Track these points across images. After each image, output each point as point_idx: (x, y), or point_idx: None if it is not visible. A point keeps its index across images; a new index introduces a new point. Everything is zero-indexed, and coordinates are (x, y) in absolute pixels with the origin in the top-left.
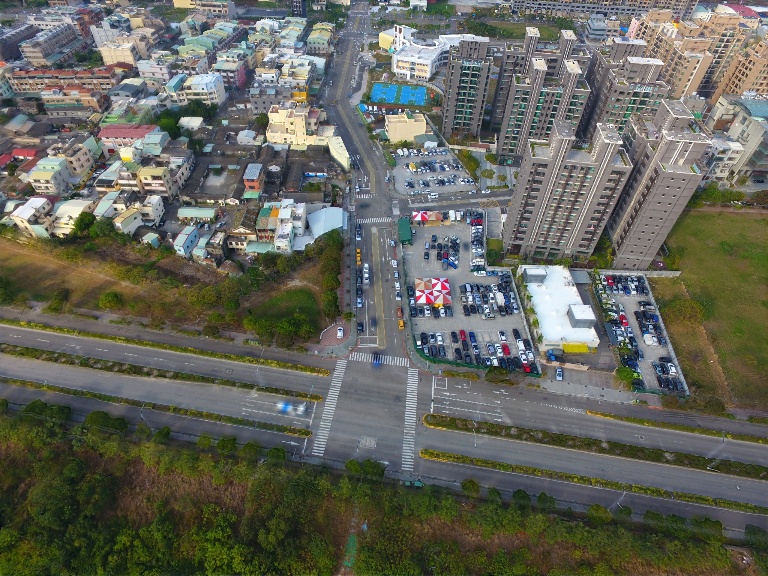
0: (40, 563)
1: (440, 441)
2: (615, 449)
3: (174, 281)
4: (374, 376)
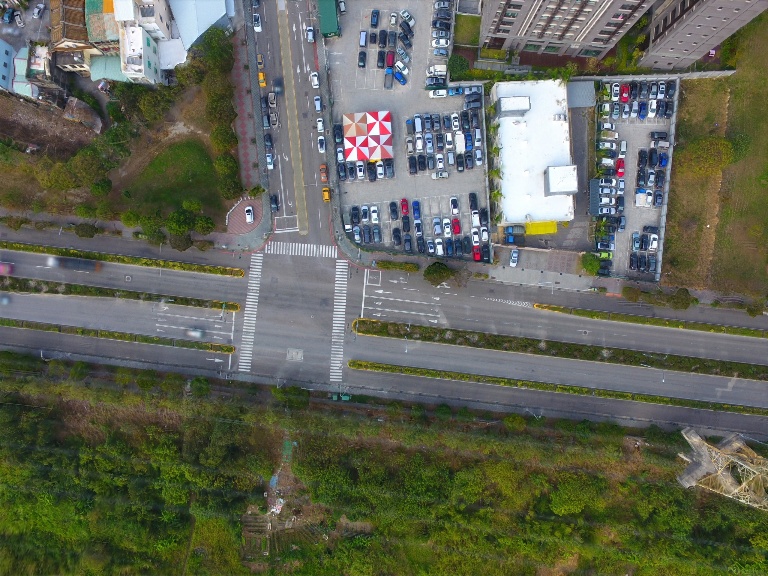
0: (24, 474)
1: (370, 349)
2: (552, 349)
3: (8, 154)
4: (296, 274)
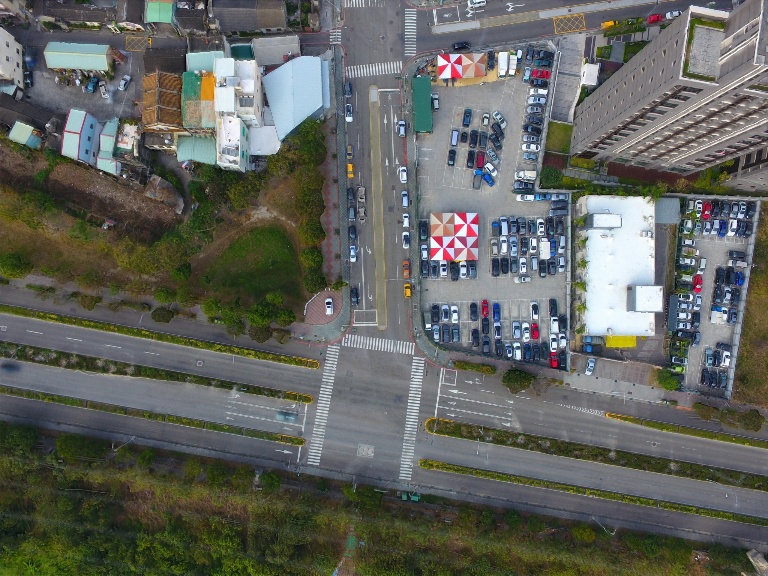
0: (76, 558)
1: (441, 449)
2: (621, 460)
3: (88, 232)
4: (372, 369)
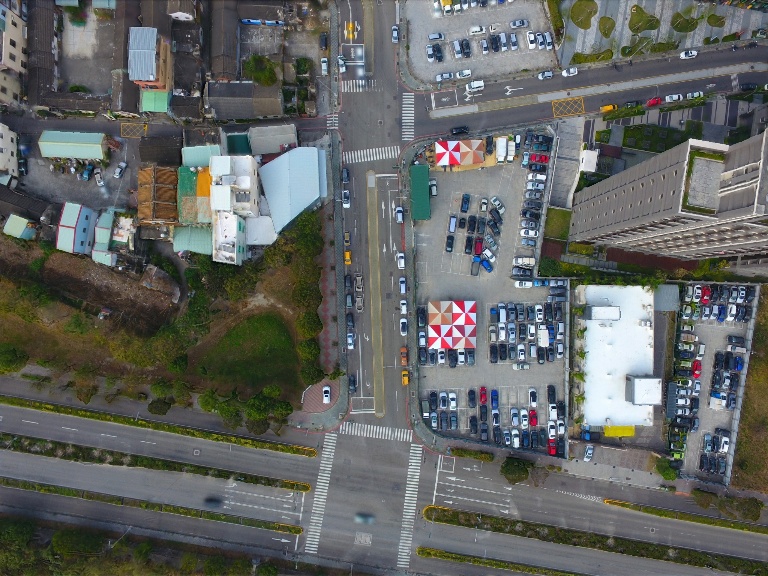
0: None
1: (439, 537)
2: (620, 547)
3: (83, 326)
4: (370, 457)
